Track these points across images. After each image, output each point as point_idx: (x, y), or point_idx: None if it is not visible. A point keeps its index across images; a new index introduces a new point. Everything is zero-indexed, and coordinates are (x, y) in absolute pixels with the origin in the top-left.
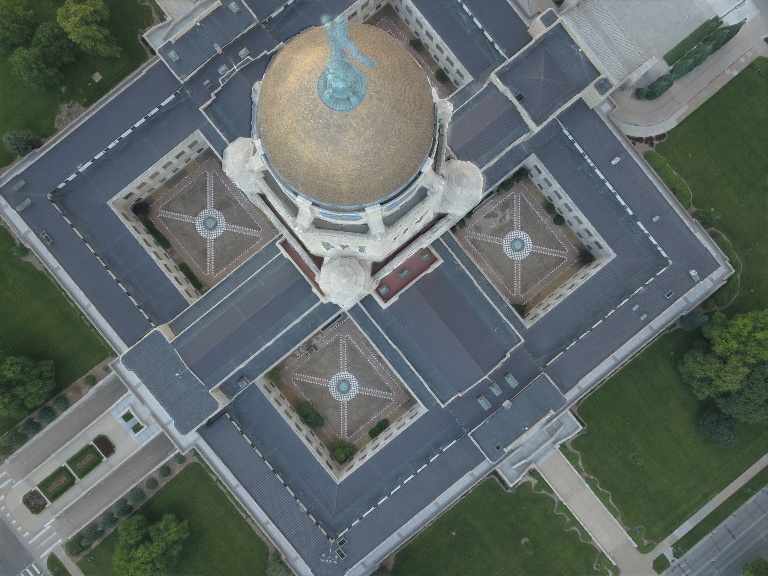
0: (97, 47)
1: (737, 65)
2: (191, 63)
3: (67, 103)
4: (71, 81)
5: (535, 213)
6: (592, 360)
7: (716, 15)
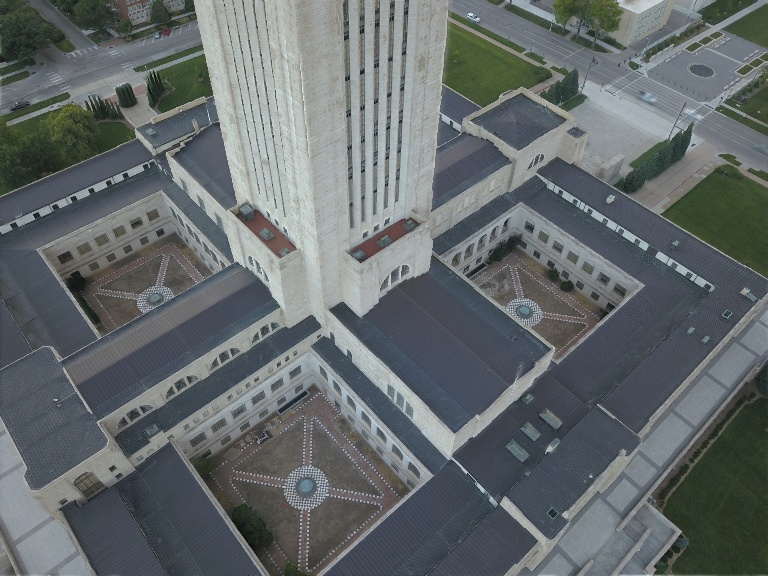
0: (78, 148)
1: (703, 171)
2: (167, 137)
3: None
4: None
5: (537, 283)
6: (658, 393)
7: (666, 139)
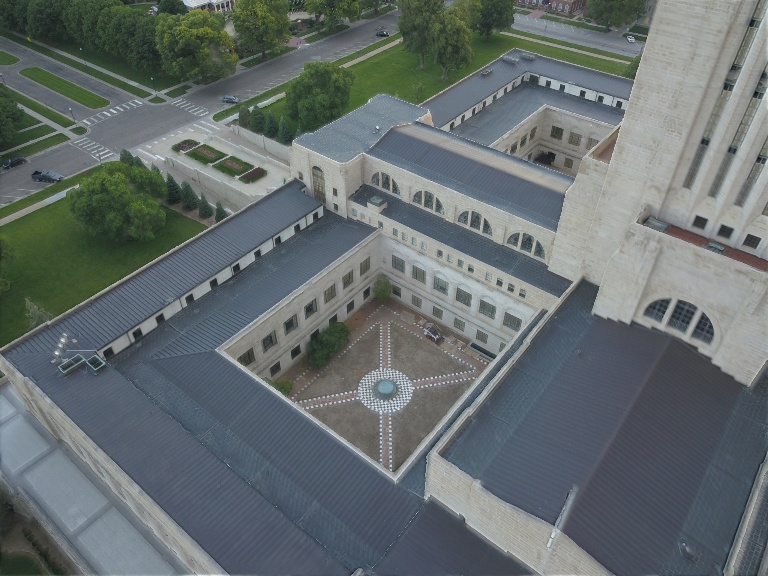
0: None
1: None
2: None
3: None
4: None
5: None
6: None
7: None
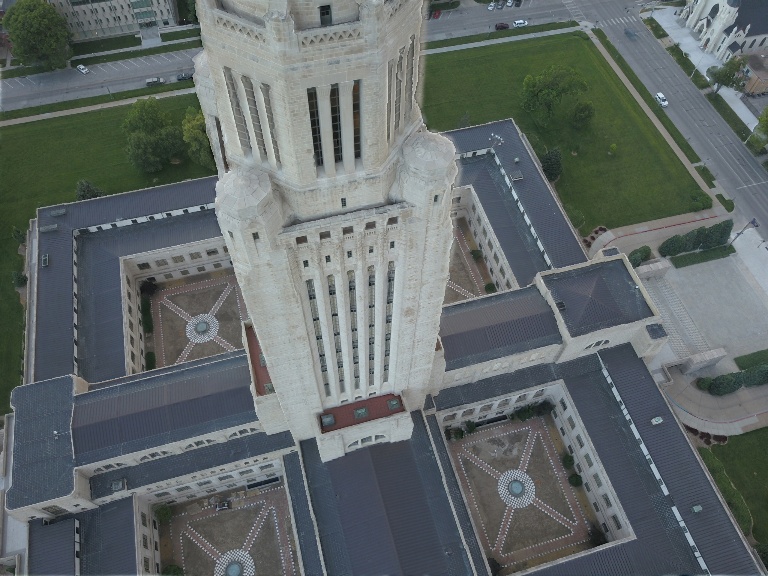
0: (200, 153)
1: None
2: None
3: None
4: (165, 177)
5: (549, 461)
6: None
7: None
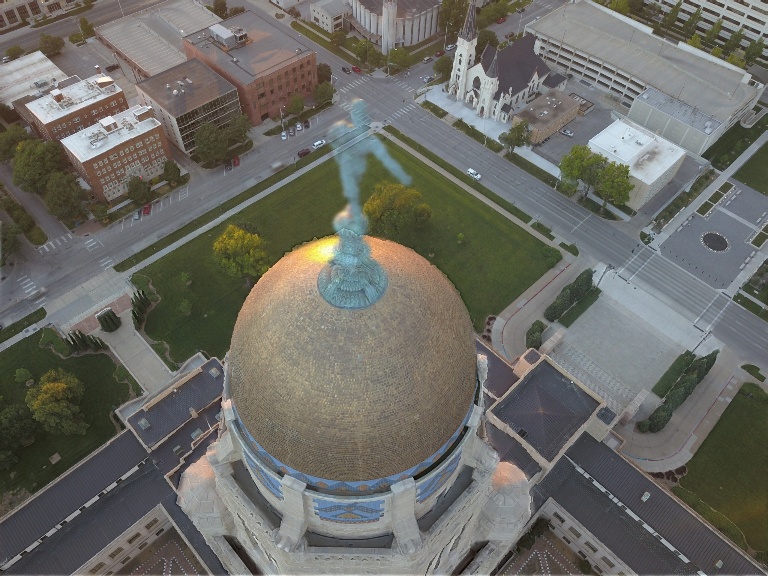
0: (62, 424)
1: (727, 392)
2: (162, 430)
3: (13, 490)
4: (24, 465)
5: (569, 575)
6: None
7: (686, 350)
